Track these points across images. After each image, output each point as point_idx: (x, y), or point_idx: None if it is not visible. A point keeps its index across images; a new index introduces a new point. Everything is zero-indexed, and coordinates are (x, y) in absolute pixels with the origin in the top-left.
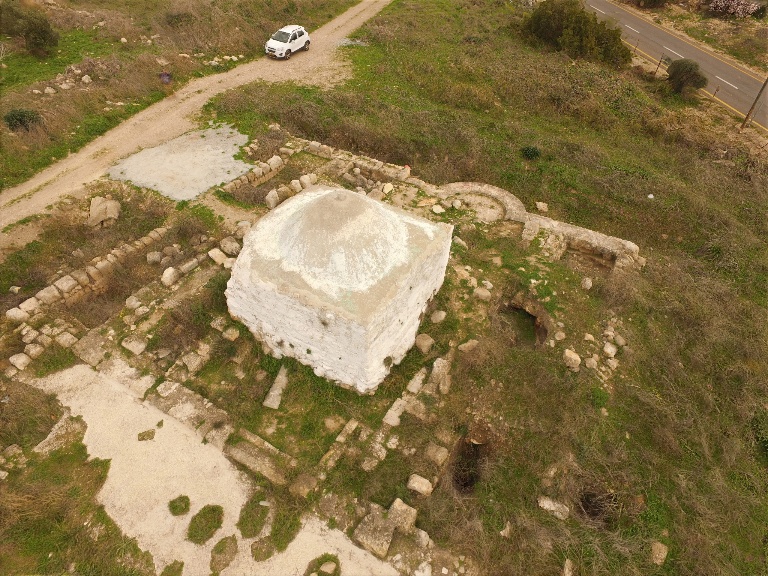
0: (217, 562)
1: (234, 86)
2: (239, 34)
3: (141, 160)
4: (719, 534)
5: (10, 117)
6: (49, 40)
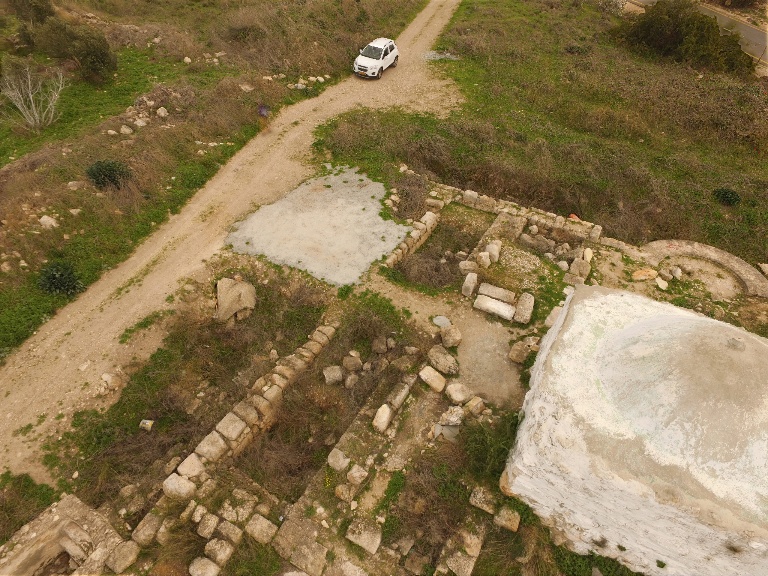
0: None
1: (333, 115)
2: (321, 50)
3: (265, 223)
4: None
5: (96, 173)
6: (108, 64)
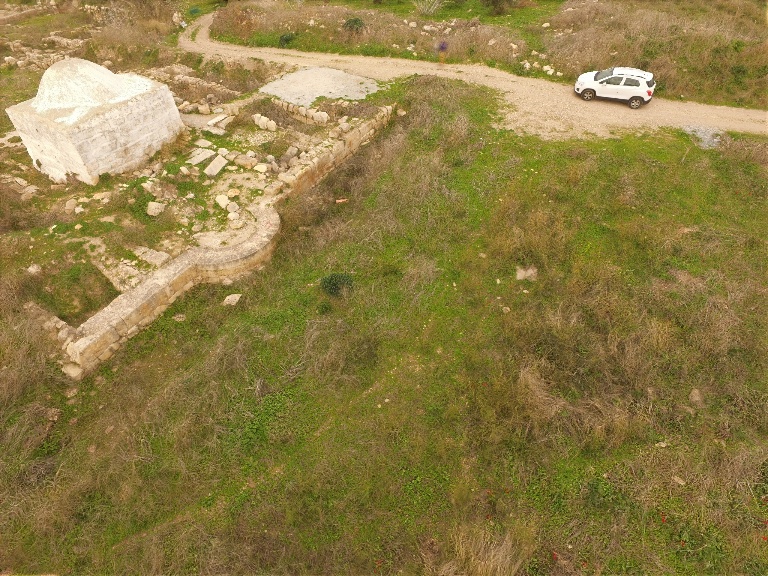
0: None
1: (483, 84)
2: (597, 56)
3: (323, 71)
4: None
5: (348, 20)
6: (494, 2)
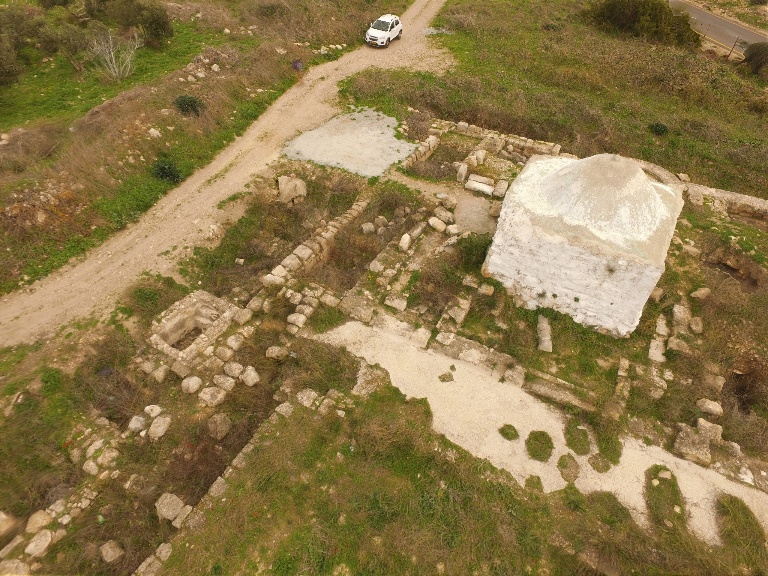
0: (567, 475)
1: (351, 73)
2: (338, 24)
3: (309, 142)
4: None
5: (182, 103)
6: (167, 31)
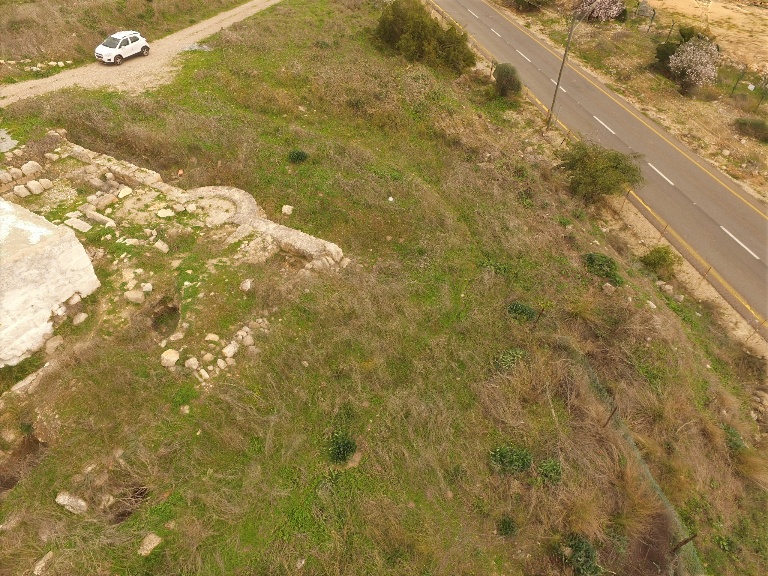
0: None
1: (44, 92)
2: (72, 40)
3: None
4: (228, 526)
5: None
6: None
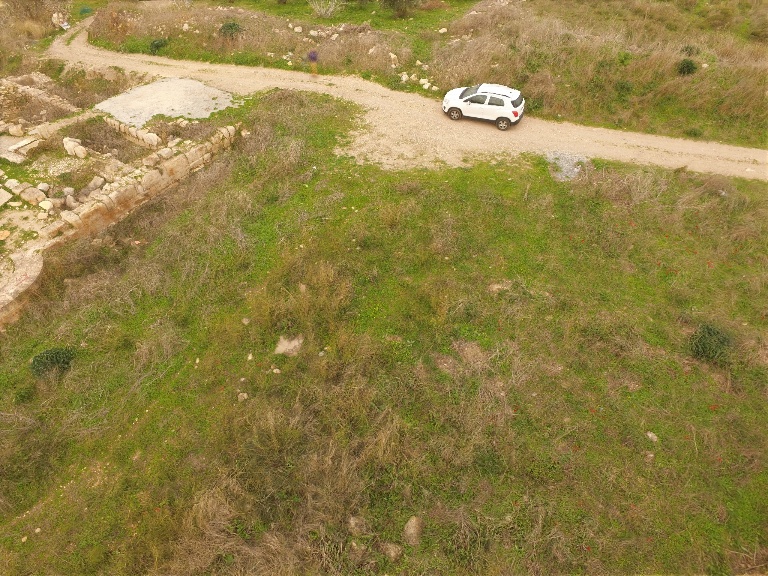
0: None
1: (350, 99)
2: (475, 69)
3: (180, 83)
4: None
5: None
6: (392, 4)
